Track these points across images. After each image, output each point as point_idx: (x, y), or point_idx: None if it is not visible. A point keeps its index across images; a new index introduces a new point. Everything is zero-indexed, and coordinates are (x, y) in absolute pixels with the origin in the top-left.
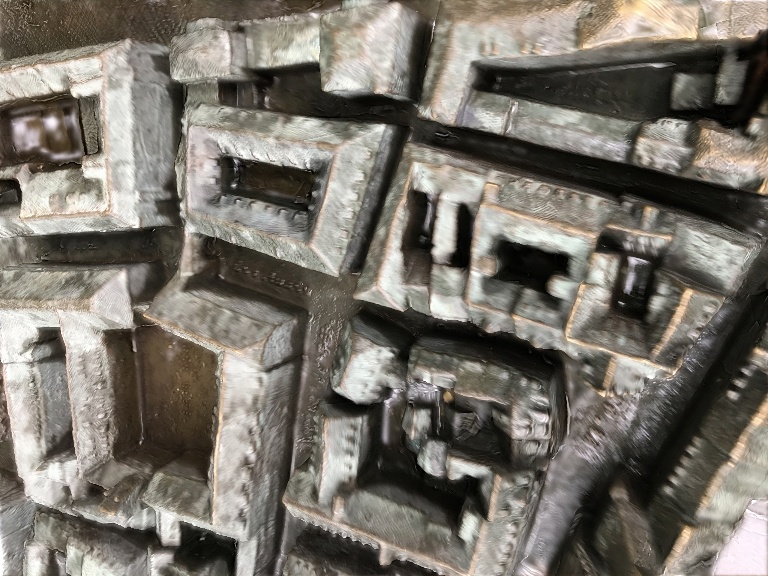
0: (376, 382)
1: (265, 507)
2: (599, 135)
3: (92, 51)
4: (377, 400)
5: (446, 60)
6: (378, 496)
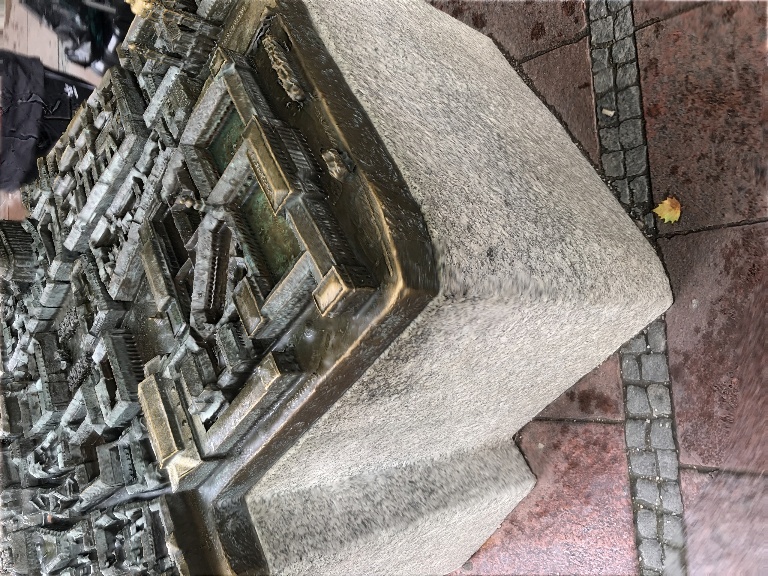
0: (122, 518)
1: (97, 499)
2: None
3: (122, 395)
4: None
5: None
6: (105, 535)
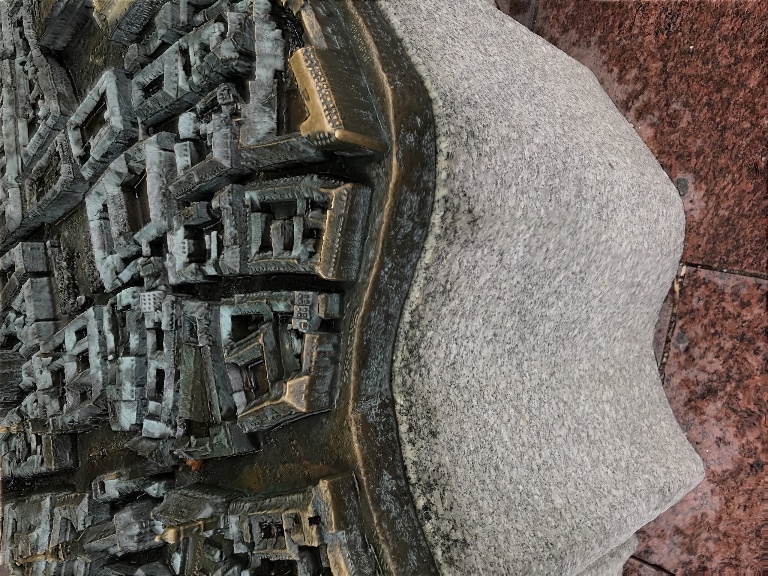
0: (193, 129)
1: None
2: (223, 1)
3: None
4: (197, 138)
5: (180, 5)
6: None
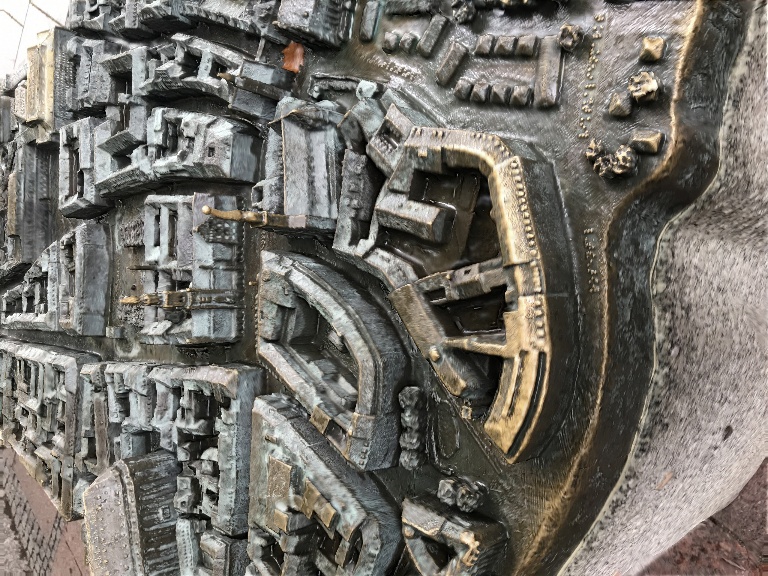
0: None
1: None
2: None
3: None
4: None
5: None
6: None
